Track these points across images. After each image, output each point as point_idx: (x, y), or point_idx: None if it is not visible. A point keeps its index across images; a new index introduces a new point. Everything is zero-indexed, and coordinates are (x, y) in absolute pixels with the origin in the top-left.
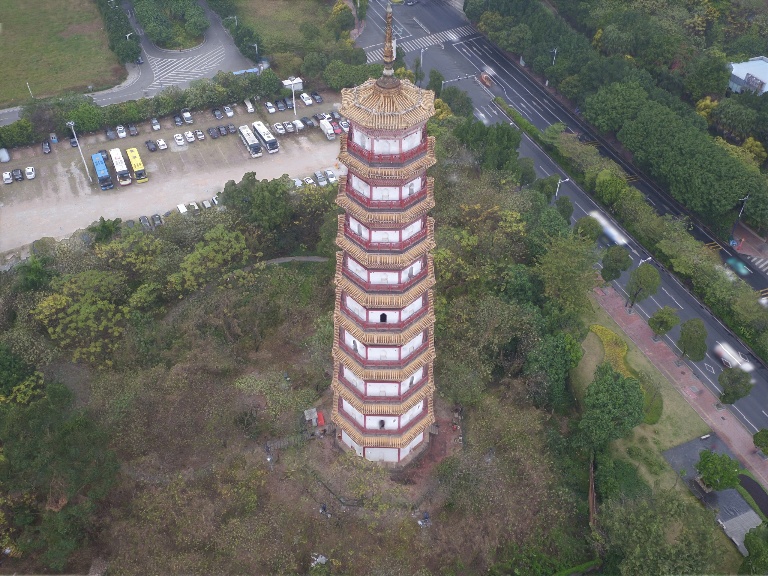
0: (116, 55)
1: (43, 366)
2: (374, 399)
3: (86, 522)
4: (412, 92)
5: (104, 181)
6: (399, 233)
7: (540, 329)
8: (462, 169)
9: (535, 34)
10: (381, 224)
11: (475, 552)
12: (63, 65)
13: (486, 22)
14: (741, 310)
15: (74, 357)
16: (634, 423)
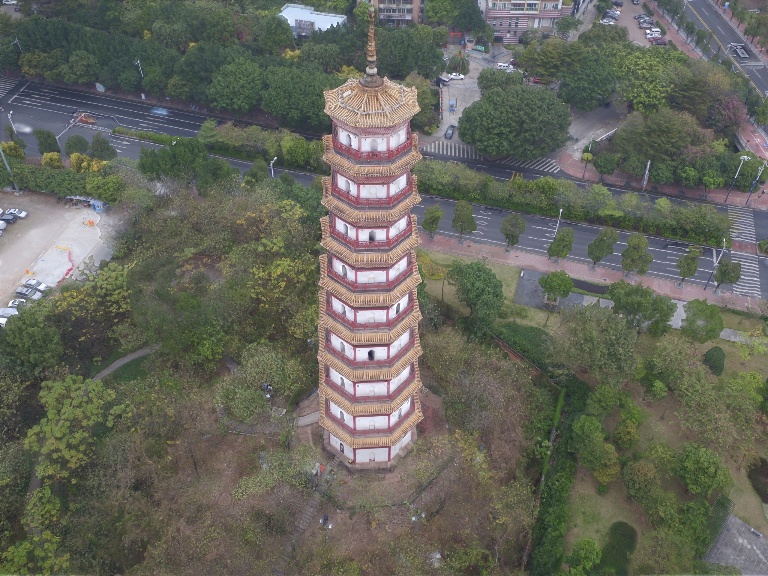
0: None
1: None
2: (398, 392)
3: None
4: None
5: None
6: (406, 218)
7: None
8: None
9: (99, 56)
10: None
11: (518, 446)
12: None
13: (30, 65)
14: (466, 181)
15: None
16: (501, 290)
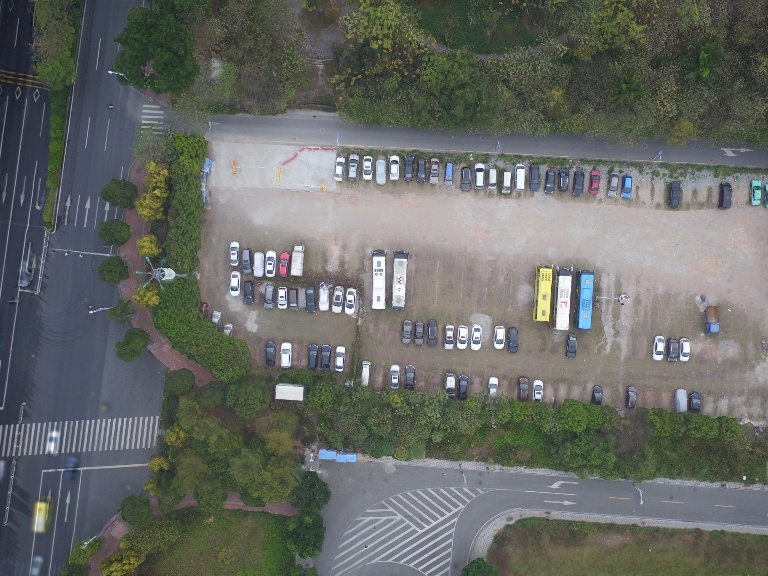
0: None
1: None
2: None
3: None
4: None
5: None
6: None
7: None
8: None
9: None
10: None
11: None
12: None
13: None
14: None
15: None
16: None
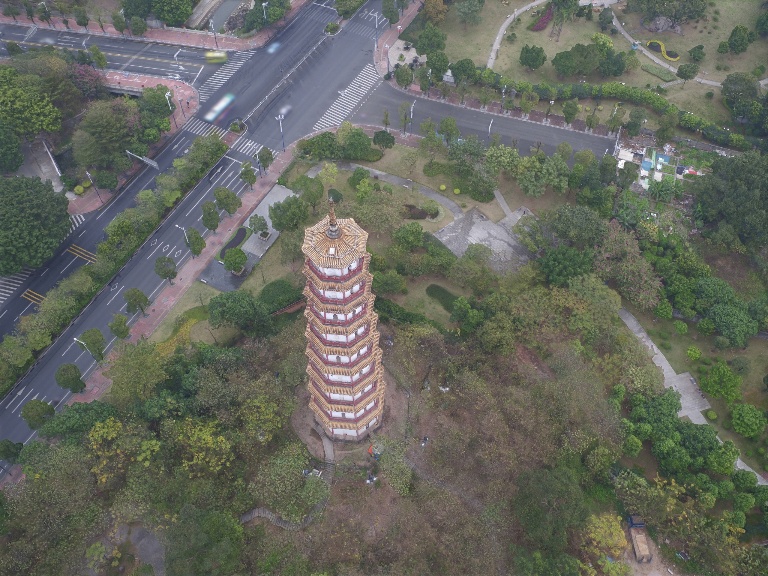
0: None
1: None
2: None
3: None
4: None
5: None
6: None
7: None
8: None
9: None
10: None
11: None
12: None
13: None
14: (85, 286)
15: None
16: None
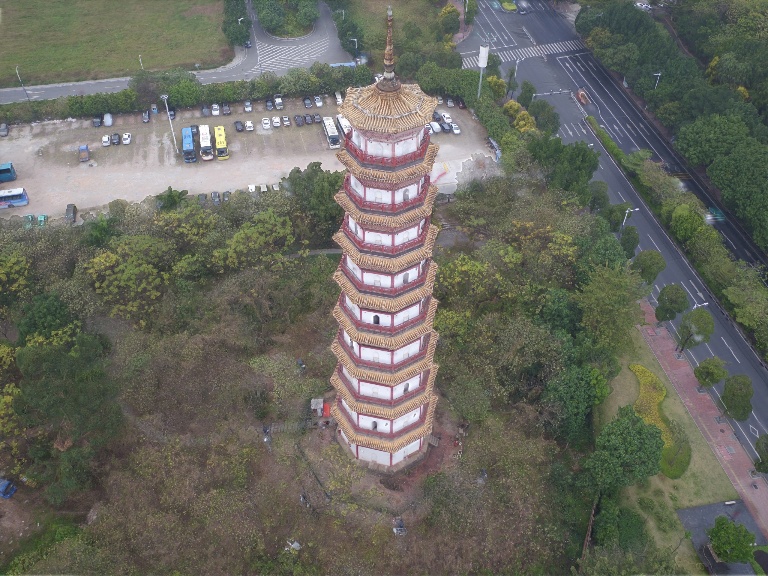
0: (226, 37)
1: (85, 316)
2: (366, 399)
3: (88, 466)
4: (414, 98)
5: (188, 154)
6: (392, 237)
7: (568, 359)
8: (528, 185)
9: (642, 55)
10: (372, 226)
11: (445, 571)
12: (179, 42)
13: (595, 38)
14: None
15: (112, 313)
16: (646, 473)
